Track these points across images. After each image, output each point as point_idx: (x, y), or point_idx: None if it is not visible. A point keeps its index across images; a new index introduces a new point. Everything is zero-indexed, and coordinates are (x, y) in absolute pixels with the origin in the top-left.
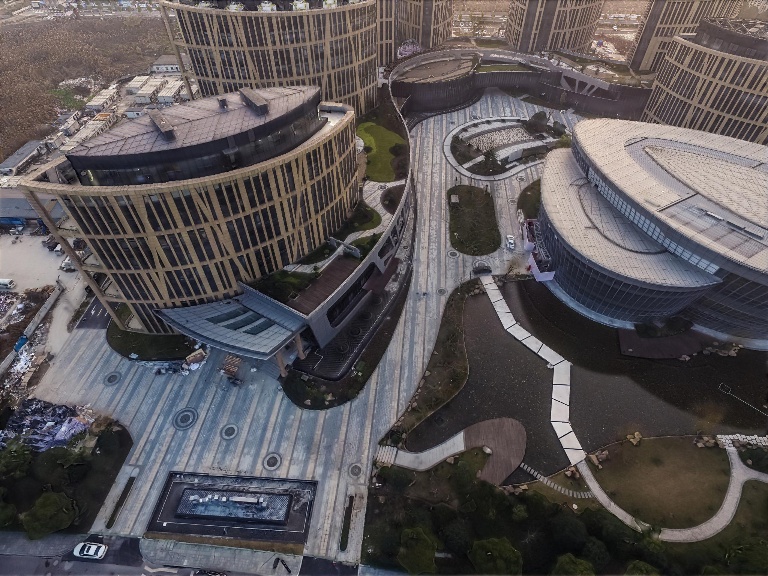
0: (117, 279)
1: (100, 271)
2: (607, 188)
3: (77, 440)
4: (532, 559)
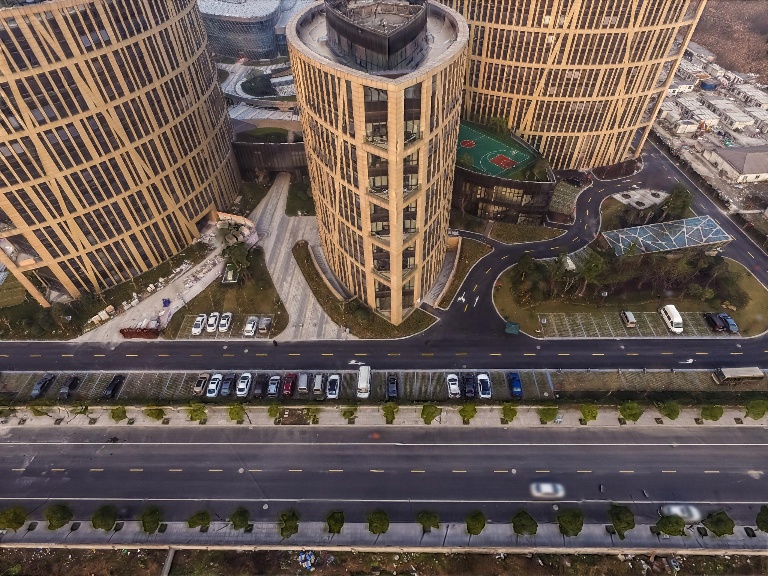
0: None
1: None
2: None
3: None
4: None
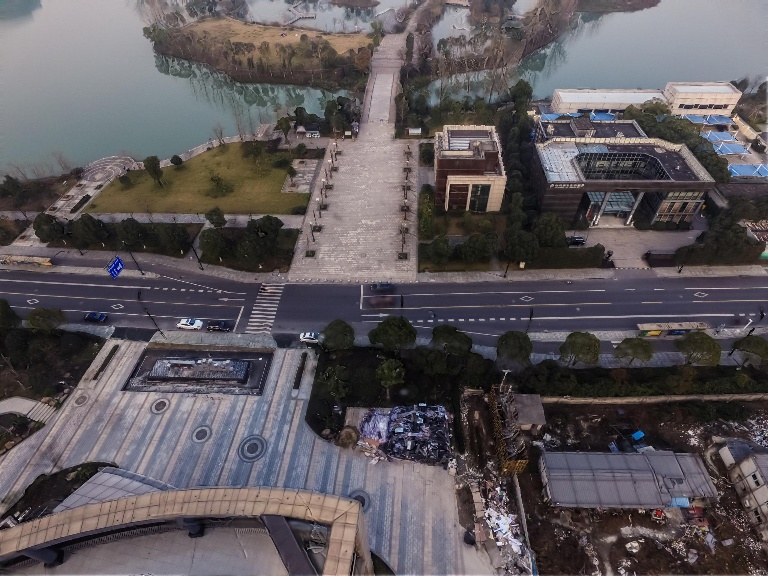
0: None
1: None
2: None
3: (366, 420)
4: None
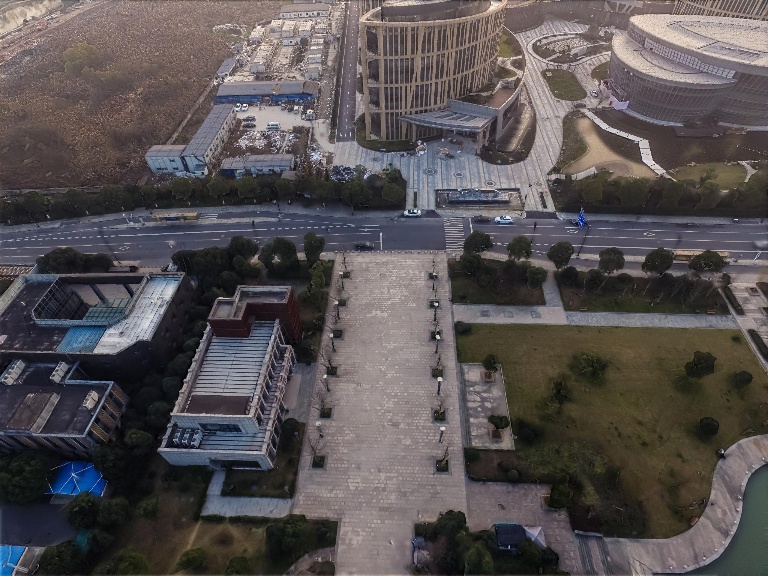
0: (386, 92)
1: (378, 86)
2: (660, 46)
3: None
4: (647, 204)
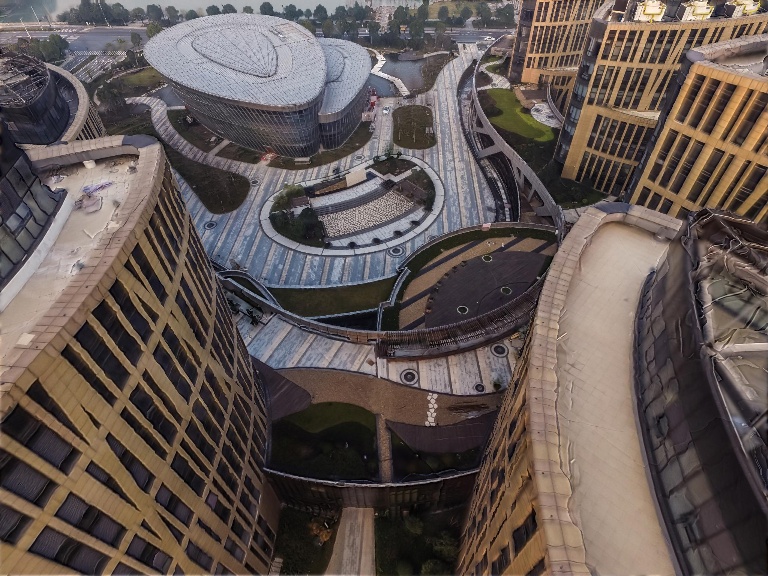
0: None
1: None
2: None
3: None
4: None
